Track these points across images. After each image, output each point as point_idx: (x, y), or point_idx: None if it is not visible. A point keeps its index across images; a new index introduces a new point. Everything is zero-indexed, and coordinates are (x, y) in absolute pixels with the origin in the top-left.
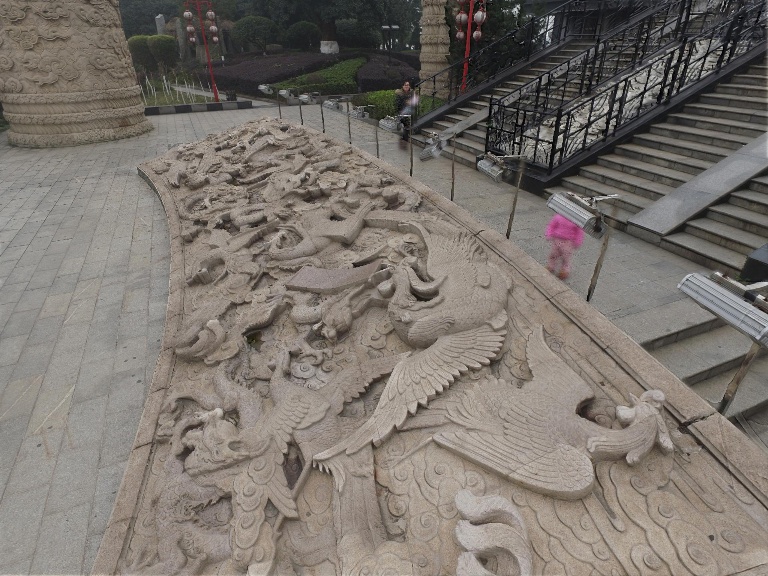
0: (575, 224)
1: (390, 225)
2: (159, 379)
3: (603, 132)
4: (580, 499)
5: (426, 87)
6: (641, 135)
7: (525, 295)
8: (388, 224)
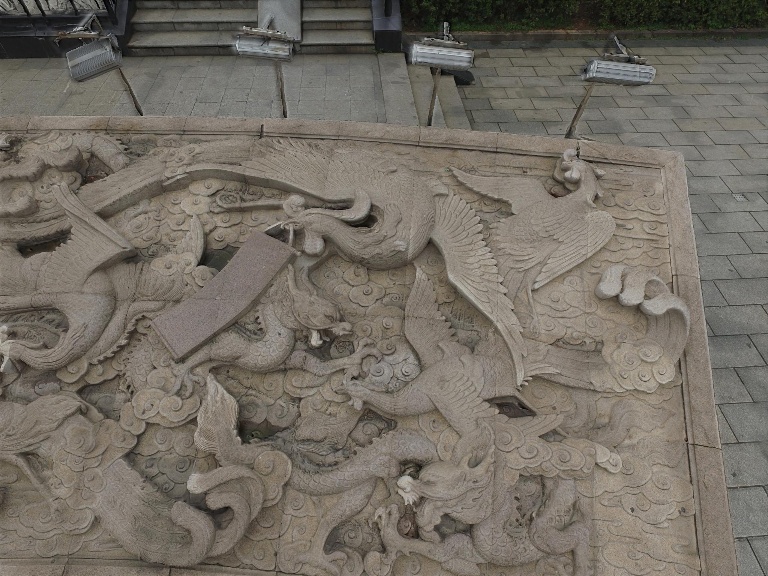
0: (461, 66)
1: (147, 193)
2: None
3: None
4: None
5: None
6: None
7: (399, 155)
8: (143, 194)
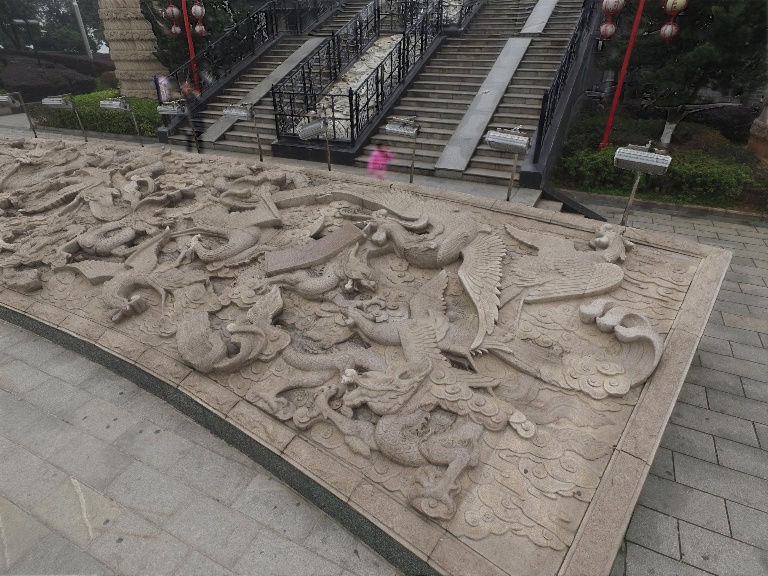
0: (518, 146)
1: (306, 201)
2: (223, 398)
3: (376, 107)
4: (619, 287)
5: (132, 88)
6: (398, 107)
7: (472, 213)
8: (304, 200)
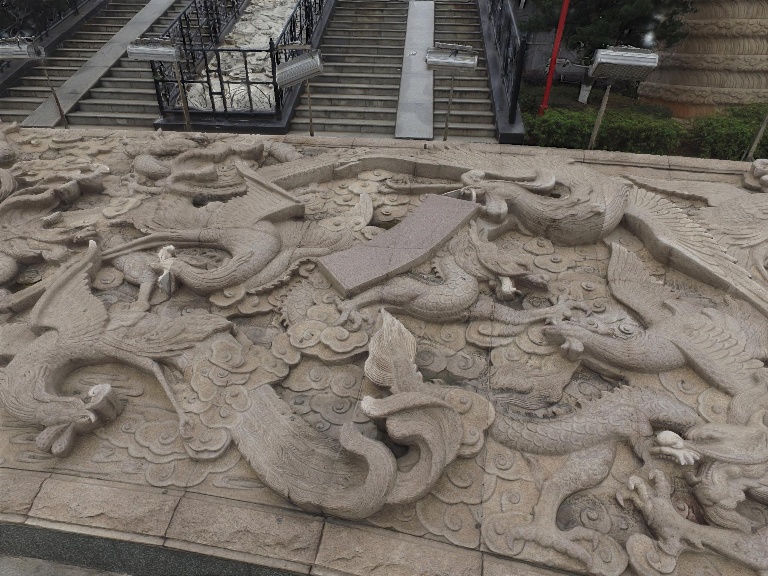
0: (645, 66)
1: (319, 175)
2: (447, 567)
3: None
4: None
5: None
6: None
7: None
8: (315, 175)
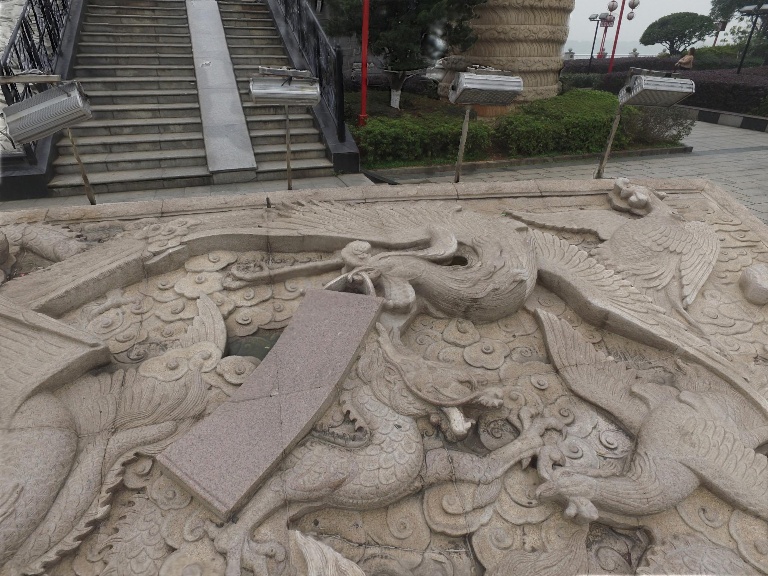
0: (512, 91)
1: (120, 278)
2: None
3: None
4: None
5: None
6: None
7: None
8: (114, 279)
